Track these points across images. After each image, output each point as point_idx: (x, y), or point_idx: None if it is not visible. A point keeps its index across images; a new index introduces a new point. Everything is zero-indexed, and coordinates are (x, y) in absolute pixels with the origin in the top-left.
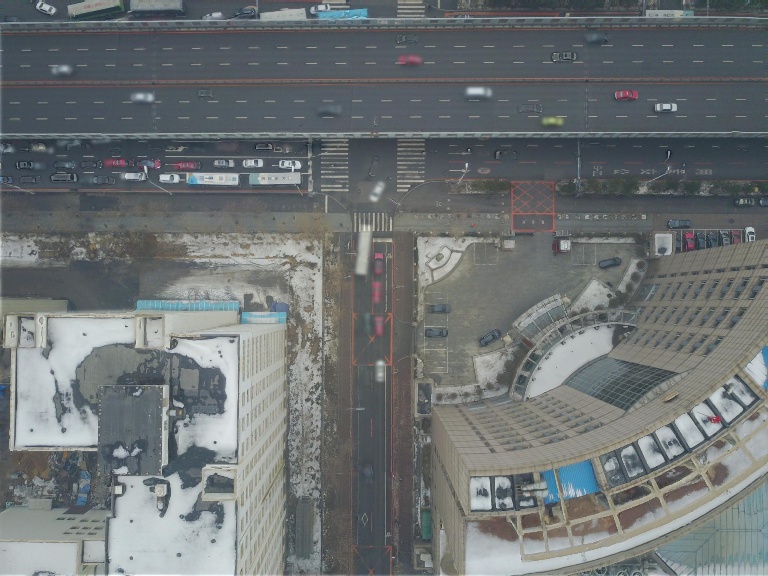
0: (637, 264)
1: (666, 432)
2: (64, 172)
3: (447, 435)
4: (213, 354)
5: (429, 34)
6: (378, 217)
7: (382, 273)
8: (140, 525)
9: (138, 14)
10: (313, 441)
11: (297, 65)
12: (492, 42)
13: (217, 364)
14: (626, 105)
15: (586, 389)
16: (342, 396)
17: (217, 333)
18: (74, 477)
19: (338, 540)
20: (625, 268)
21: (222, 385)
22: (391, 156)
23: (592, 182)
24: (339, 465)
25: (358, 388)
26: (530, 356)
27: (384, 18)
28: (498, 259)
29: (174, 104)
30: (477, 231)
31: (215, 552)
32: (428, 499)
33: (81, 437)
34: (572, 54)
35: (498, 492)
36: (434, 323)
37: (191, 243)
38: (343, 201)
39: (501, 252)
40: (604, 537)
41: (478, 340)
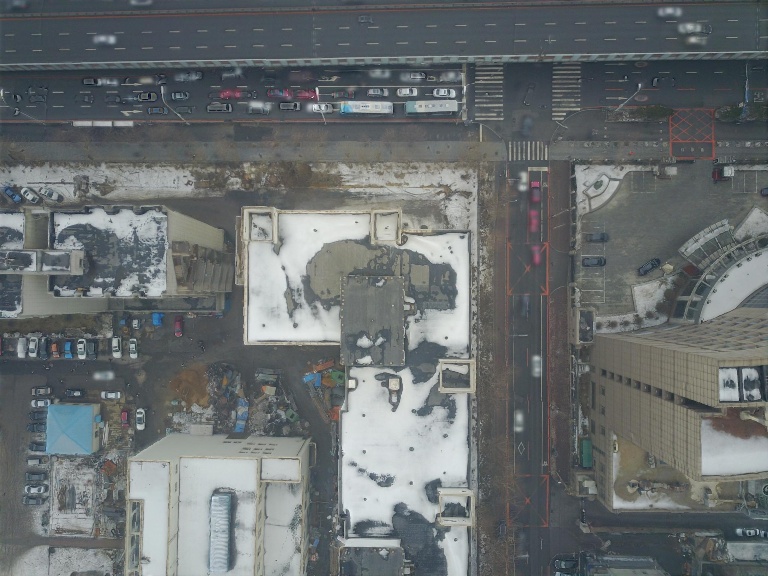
0: None
1: None
2: (218, 103)
3: (646, 346)
4: (443, 250)
5: None
6: (533, 146)
7: (538, 202)
8: (372, 419)
9: None
10: None
11: None
12: None
13: (447, 260)
14: None
15: None
16: (497, 326)
17: None
18: (233, 404)
19: (503, 465)
20: None
21: (453, 281)
22: (546, 84)
23: (759, 106)
24: (502, 391)
25: (513, 318)
26: (704, 279)
27: None
28: (656, 187)
29: (334, 30)
30: (636, 159)
31: (447, 447)
32: (586, 428)
33: (312, 332)
34: None
35: (746, 384)
36: (591, 252)
37: (346, 172)
38: (498, 130)
39: (659, 180)
40: None
41: (636, 269)
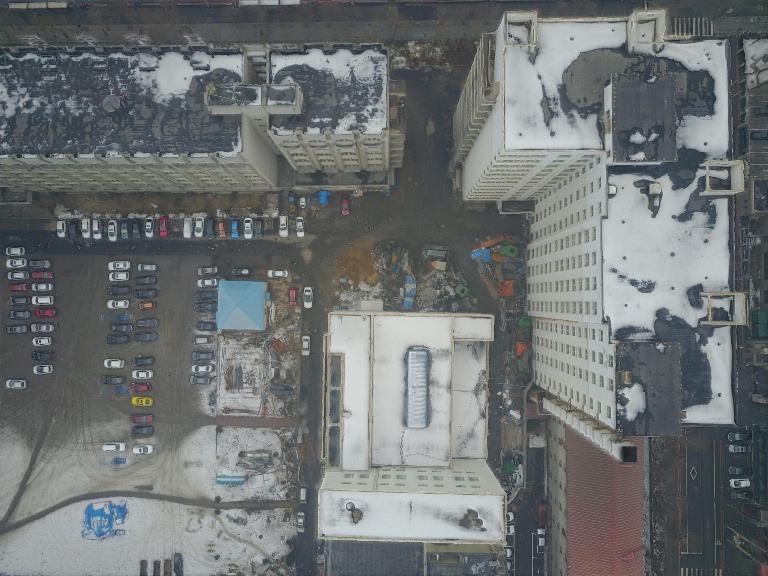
0: None
1: None
2: None
3: None
4: (700, 57)
5: None
6: (698, 22)
7: None
8: (632, 226)
9: None
10: None
11: None
12: None
13: (705, 67)
14: None
15: None
16: None
17: None
18: (401, 281)
19: None
20: None
21: (711, 87)
22: None
23: None
24: None
25: None
26: None
27: None
28: None
29: None
30: None
31: (708, 252)
32: (758, 301)
33: (570, 141)
34: None
35: None
36: (759, 126)
37: None
38: (663, 7)
39: None
40: None
41: None
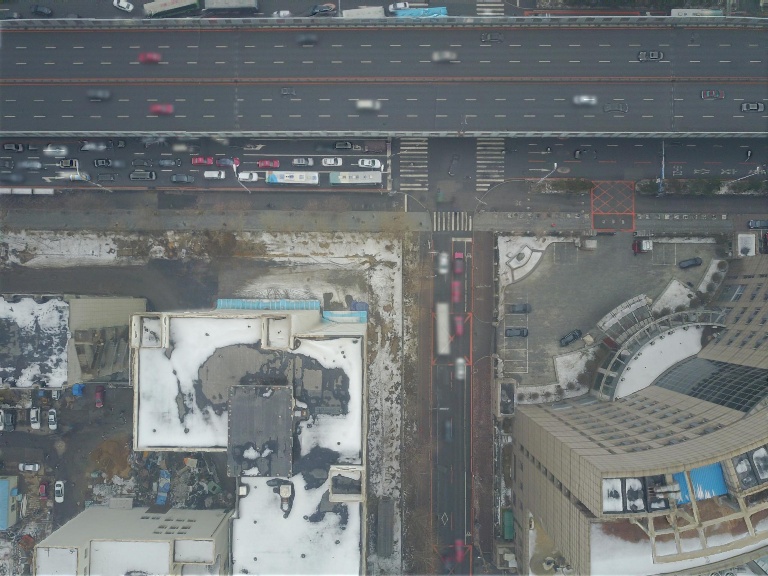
0: (718, 264)
1: None
2: (142, 170)
3: (551, 436)
4: (336, 355)
5: (514, 33)
6: (457, 216)
7: (462, 272)
8: (264, 526)
9: (218, 11)
10: (393, 441)
11: (381, 63)
12: (578, 41)
13: (340, 365)
14: (713, 105)
15: (685, 390)
16: (421, 396)
17: (340, 334)
18: (154, 476)
19: (423, 540)
20: (705, 268)
21: (345, 386)
22: (471, 155)
23: (675, 182)
24: (423, 465)
25: (438, 388)
26: (619, 356)
27: (469, 16)
28: (578, 259)
29: (257, 102)
30: (558, 231)
31: (339, 553)
32: (509, 499)
33: (204, 438)
34: (659, 53)
35: (629, 494)
36: (514, 323)
37: (270, 242)
38: (422, 200)
39: (581, 252)
40: (727, 539)
41: (558, 340)
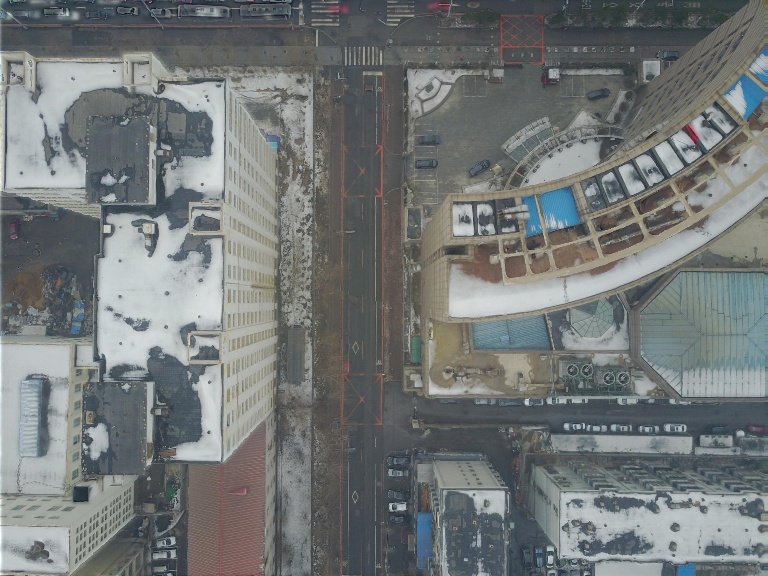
0: (625, 94)
1: (646, 160)
2: (57, 7)
3: None
4: (200, 98)
5: None
6: (368, 51)
7: (372, 105)
8: (129, 265)
9: None
10: (304, 271)
11: None
12: None
13: (204, 108)
14: None
15: None
16: (333, 228)
17: (204, 78)
18: (68, 306)
19: (329, 358)
20: (614, 99)
21: (209, 128)
22: None
23: (580, 9)
24: (329, 287)
25: (349, 219)
26: (518, 170)
27: None
28: (487, 91)
29: None
30: (466, 63)
31: (202, 291)
32: (418, 327)
33: (70, 180)
34: None
35: (480, 219)
36: (424, 155)
37: None
38: (333, 35)
39: (490, 84)
40: (586, 278)
41: (468, 171)
